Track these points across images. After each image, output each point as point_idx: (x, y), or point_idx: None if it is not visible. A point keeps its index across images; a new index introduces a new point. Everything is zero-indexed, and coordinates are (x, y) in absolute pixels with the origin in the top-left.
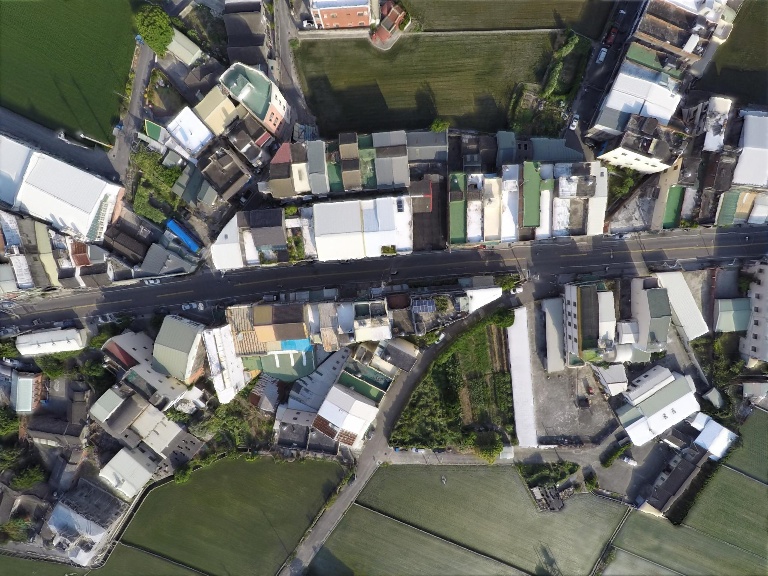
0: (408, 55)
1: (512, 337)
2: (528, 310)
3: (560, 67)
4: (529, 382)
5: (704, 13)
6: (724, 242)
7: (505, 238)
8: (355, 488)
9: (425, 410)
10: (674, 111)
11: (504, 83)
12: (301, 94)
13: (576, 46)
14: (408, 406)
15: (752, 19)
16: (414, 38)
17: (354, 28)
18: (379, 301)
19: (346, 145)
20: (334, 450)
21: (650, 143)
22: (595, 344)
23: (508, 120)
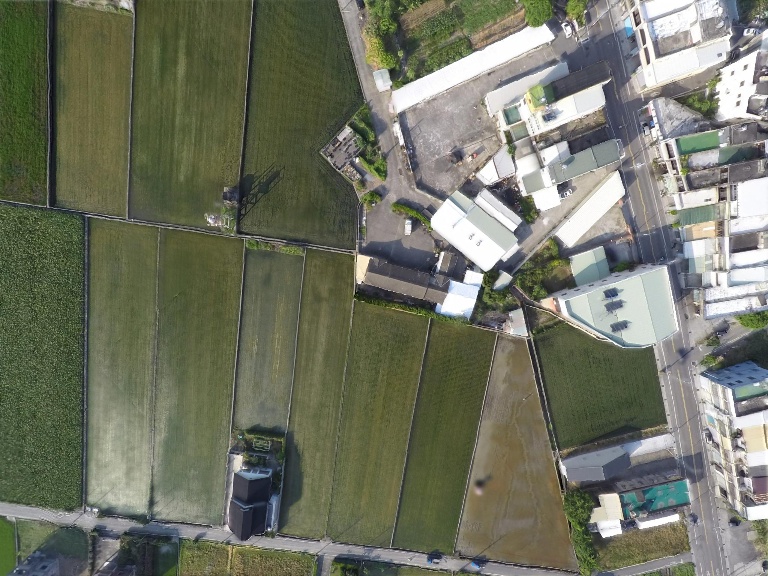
0: None
1: (516, 38)
2: (545, 55)
3: None
4: (471, 75)
5: None
6: (655, 238)
7: None
8: None
9: None
10: None
11: None
12: None
13: None
14: None
15: None
16: None
17: None
18: None
19: None
20: None
21: None
22: None
23: None
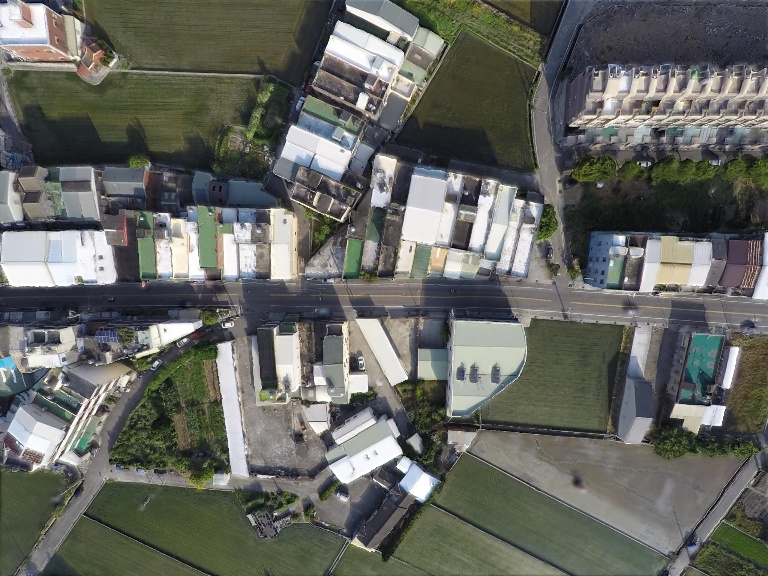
0: (118, 91)
1: (221, 370)
2: (242, 344)
3: (260, 113)
4: (238, 414)
5: (376, 72)
6: (430, 293)
7: (194, 276)
8: (84, 501)
9: (142, 433)
10: (345, 166)
11: (211, 124)
12: (15, 122)
13: (273, 93)
14: (127, 427)
15: (452, 77)
16: (122, 75)
17: (59, 62)
18: (55, 330)
19: (25, 178)
20: (30, 466)
21: (314, 196)
22: (276, 385)
23: (215, 160)
